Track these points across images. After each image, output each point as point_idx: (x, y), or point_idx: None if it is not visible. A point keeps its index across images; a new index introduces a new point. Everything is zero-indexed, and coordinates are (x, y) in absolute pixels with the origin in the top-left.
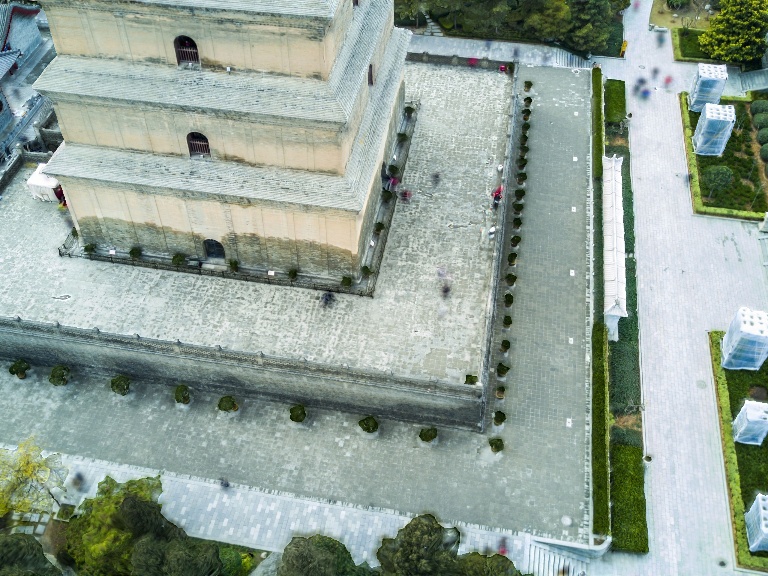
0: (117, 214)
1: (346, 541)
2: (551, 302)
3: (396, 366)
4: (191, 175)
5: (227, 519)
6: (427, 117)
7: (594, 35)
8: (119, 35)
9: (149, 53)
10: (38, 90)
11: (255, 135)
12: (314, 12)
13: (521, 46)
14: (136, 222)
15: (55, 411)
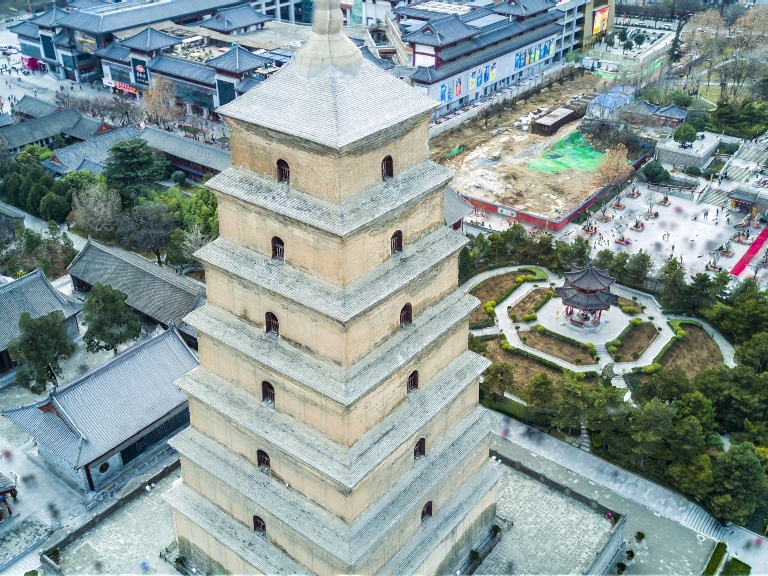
0: (202, 546)
1: None
2: None
3: None
4: (249, 545)
5: None
6: (511, 541)
7: (733, 507)
8: (226, 432)
9: (242, 451)
10: (171, 445)
11: (296, 539)
12: (340, 478)
13: (659, 489)
14: (212, 557)
15: None
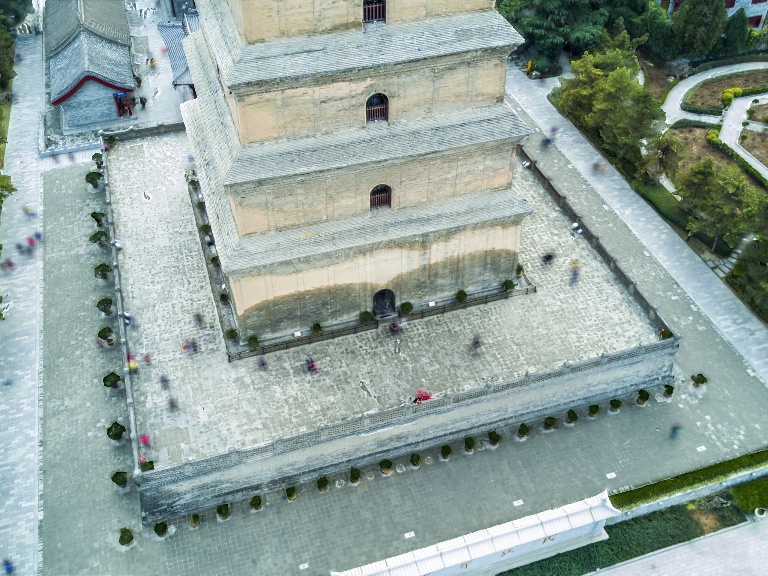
0: None
1: (5, 468)
2: (351, 527)
3: (155, 410)
4: (206, 165)
5: (9, 386)
6: (519, 304)
7: None
8: None
9: None
10: None
11: None
12: None
13: None
14: None
15: (77, 254)
